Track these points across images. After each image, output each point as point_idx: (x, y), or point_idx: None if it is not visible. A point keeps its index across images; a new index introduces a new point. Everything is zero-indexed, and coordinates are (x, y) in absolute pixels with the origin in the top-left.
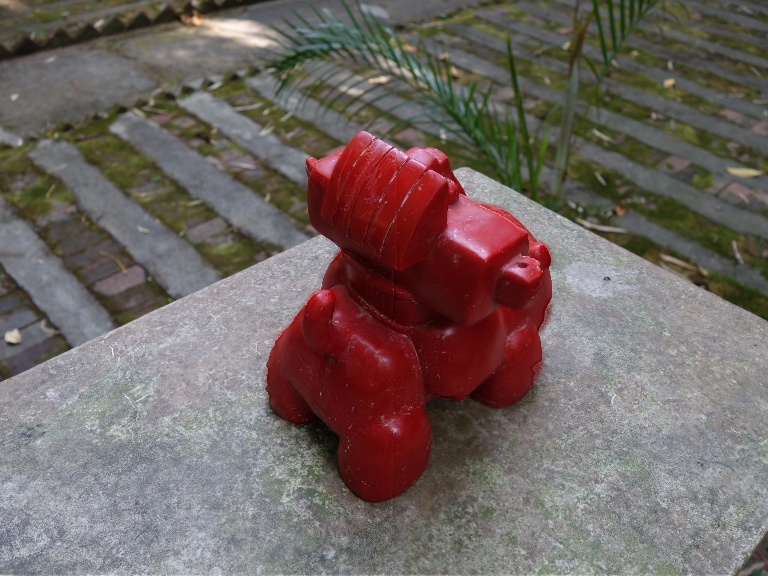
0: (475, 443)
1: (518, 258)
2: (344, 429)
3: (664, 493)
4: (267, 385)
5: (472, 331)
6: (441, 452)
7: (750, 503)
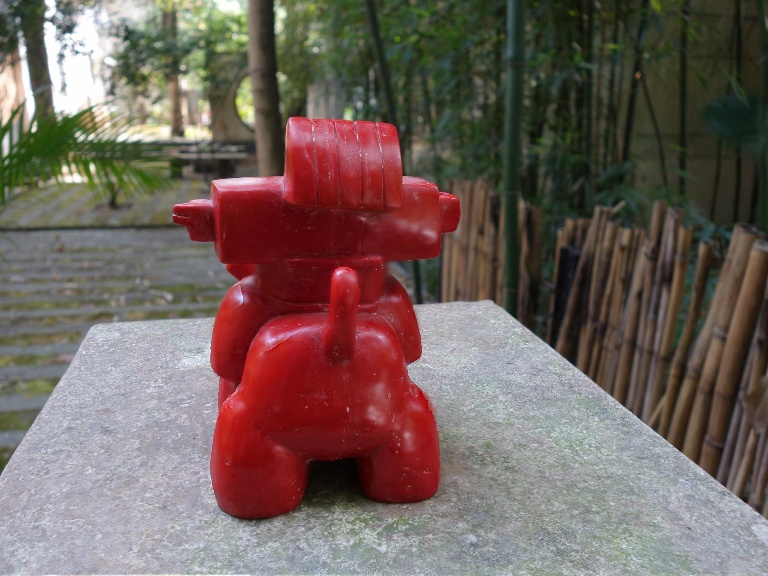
0: None
1: None
2: (388, 427)
3: (523, 381)
4: (224, 503)
5: None
6: None
7: (551, 361)
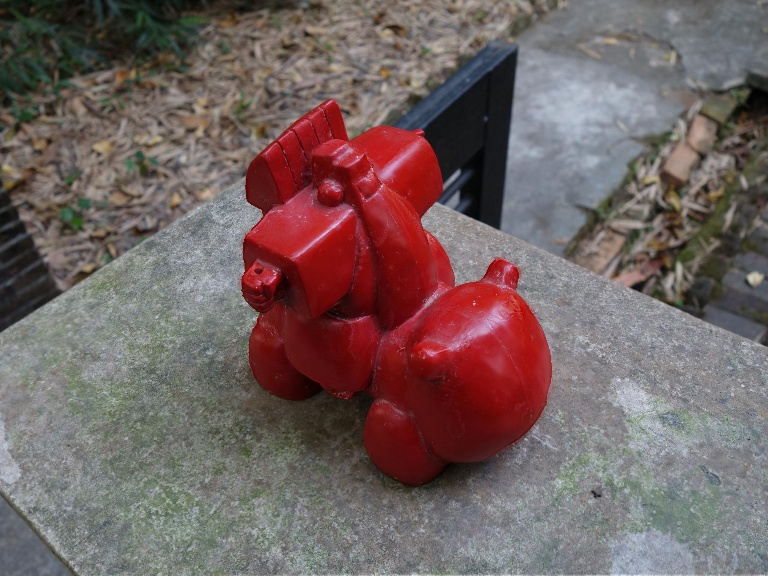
0: (321, 436)
1: (270, 267)
2: None
3: None
4: None
5: (305, 323)
6: (308, 410)
7: None
